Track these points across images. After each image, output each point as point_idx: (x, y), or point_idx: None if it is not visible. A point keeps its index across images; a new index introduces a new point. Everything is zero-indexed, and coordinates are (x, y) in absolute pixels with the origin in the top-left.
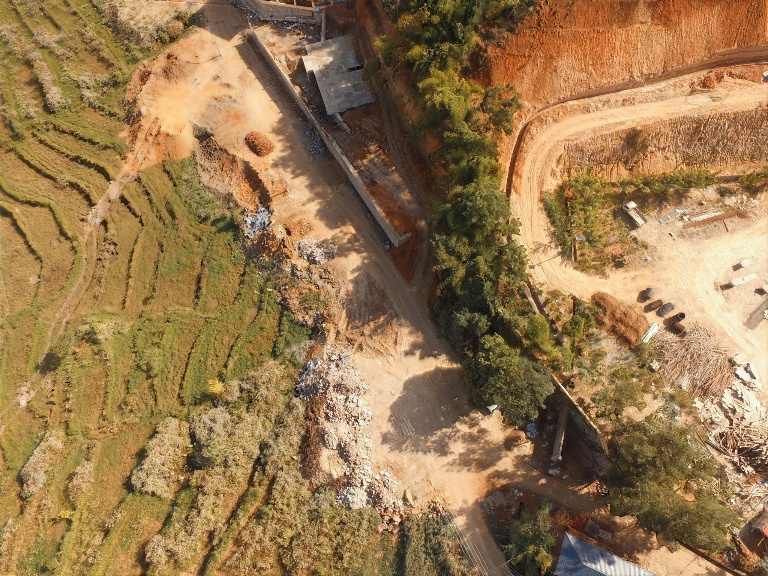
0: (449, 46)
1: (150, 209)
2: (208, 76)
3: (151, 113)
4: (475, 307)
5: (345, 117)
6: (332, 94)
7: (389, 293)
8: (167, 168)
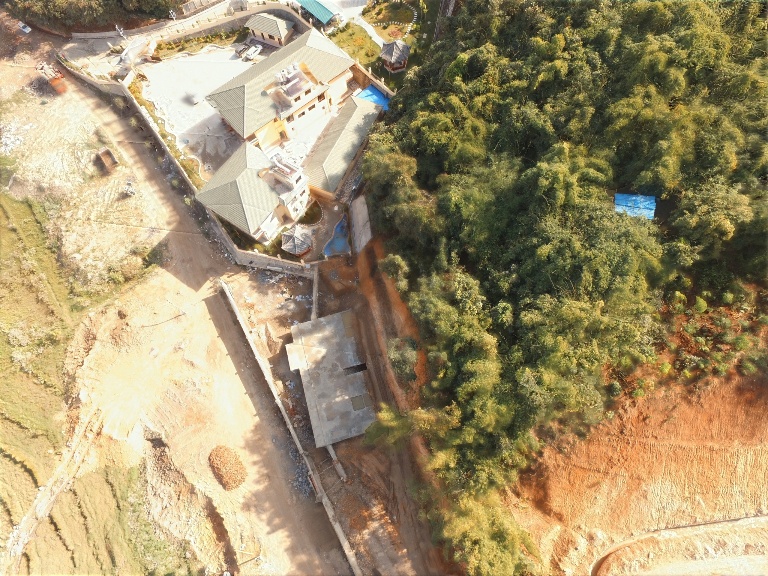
0: (489, 474)
1: (85, 540)
2: (168, 345)
3: (92, 401)
4: None
5: (340, 455)
6: (323, 413)
7: None
8: (110, 480)
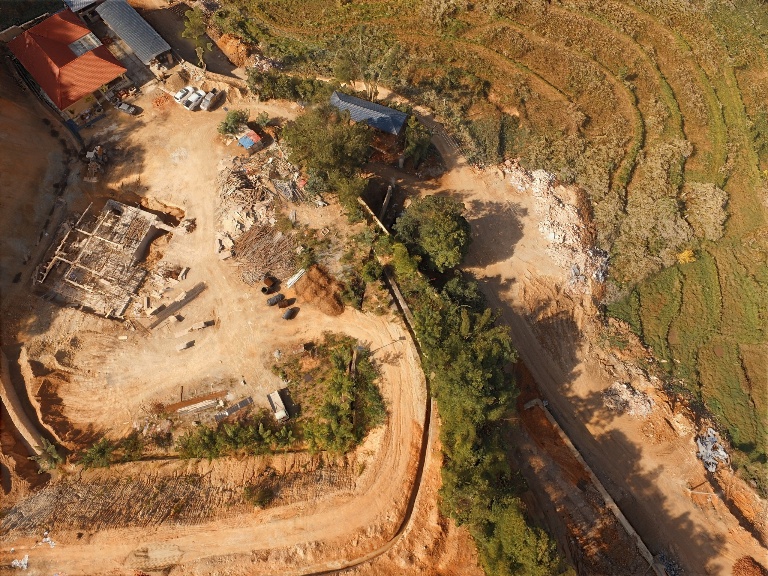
0: None
1: None
2: None
3: None
4: (459, 303)
5: None
6: None
7: (537, 344)
8: None
